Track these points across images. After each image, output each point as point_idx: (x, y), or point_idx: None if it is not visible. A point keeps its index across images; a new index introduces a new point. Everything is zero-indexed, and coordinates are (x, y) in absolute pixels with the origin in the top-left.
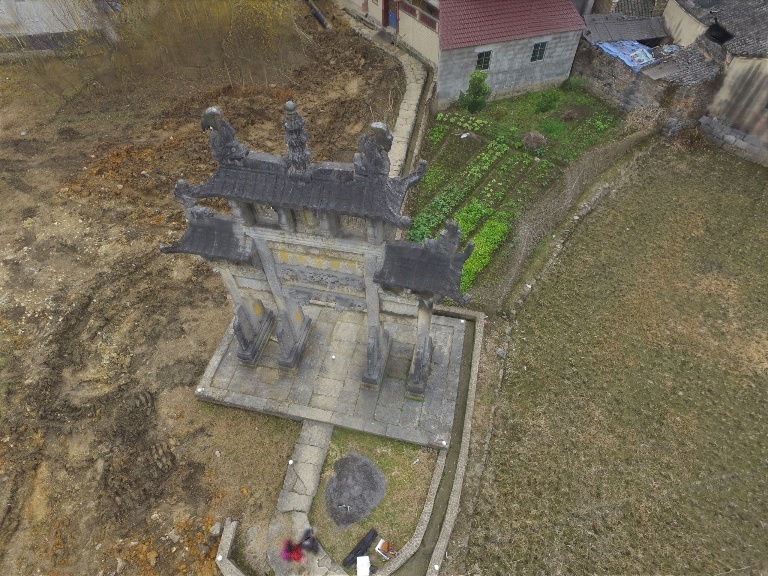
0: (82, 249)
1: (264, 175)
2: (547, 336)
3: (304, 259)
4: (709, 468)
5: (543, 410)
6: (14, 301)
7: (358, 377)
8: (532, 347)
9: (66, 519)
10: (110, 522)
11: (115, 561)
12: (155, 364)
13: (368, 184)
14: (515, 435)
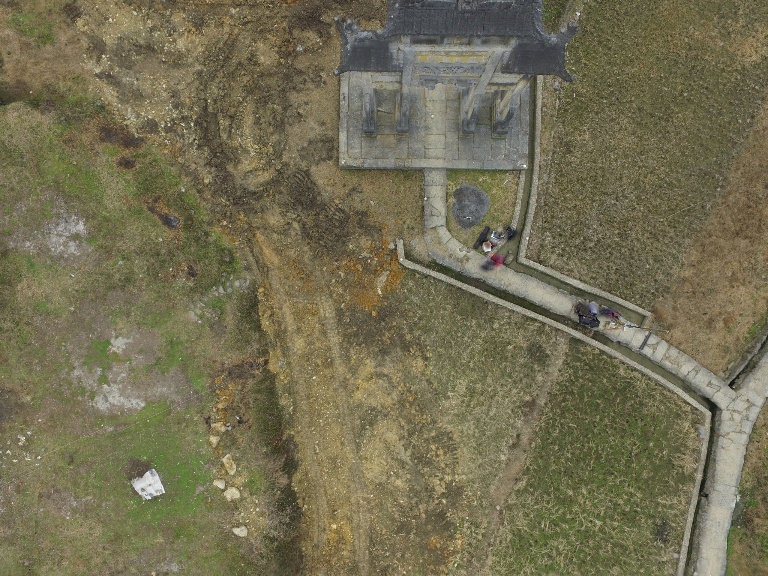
0: (159, 47)
1: (437, 11)
2: (591, 62)
3: (440, 58)
4: (693, 147)
5: (587, 127)
6: (141, 115)
7: (455, 129)
8: (580, 75)
9: (296, 259)
10: (325, 255)
11: (338, 274)
12: (294, 148)
13: (521, 9)
14: (568, 150)
